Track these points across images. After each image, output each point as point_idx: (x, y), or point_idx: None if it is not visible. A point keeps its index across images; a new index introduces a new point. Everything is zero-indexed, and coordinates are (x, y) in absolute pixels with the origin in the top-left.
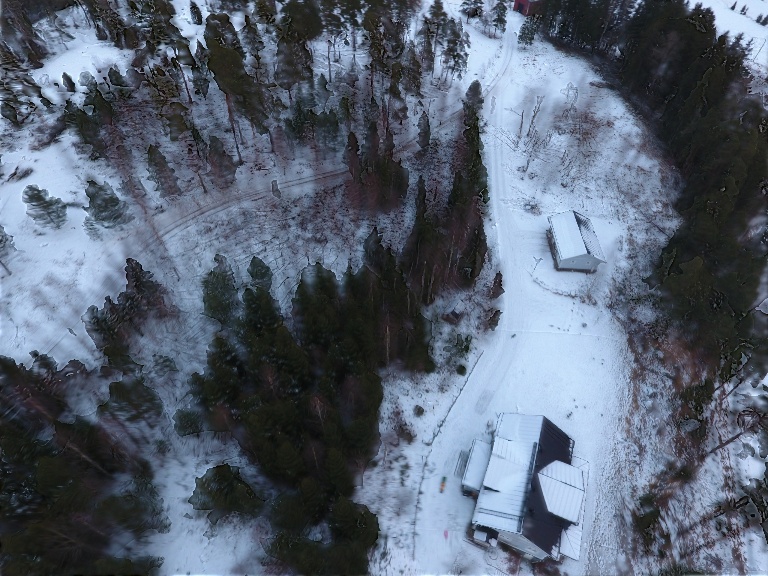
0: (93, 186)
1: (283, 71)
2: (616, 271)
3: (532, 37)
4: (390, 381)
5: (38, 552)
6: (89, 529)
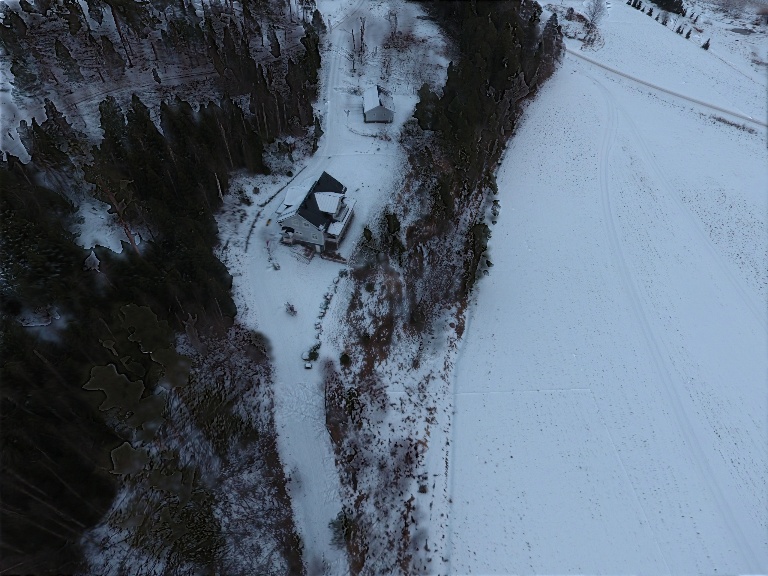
0: (16, 65)
1: None
2: (408, 122)
3: None
4: (238, 178)
5: (4, 200)
6: (33, 198)
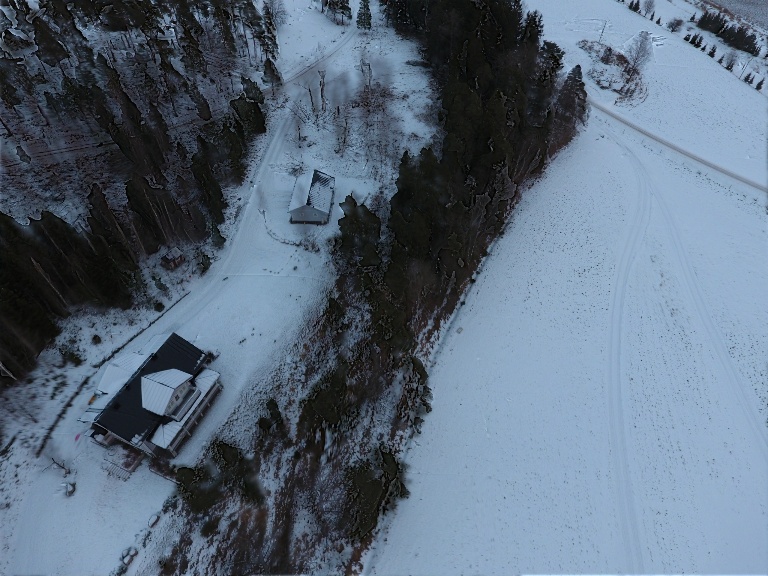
0: None
1: (44, 48)
2: None
3: (369, 22)
4: (79, 316)
5: None
6: None
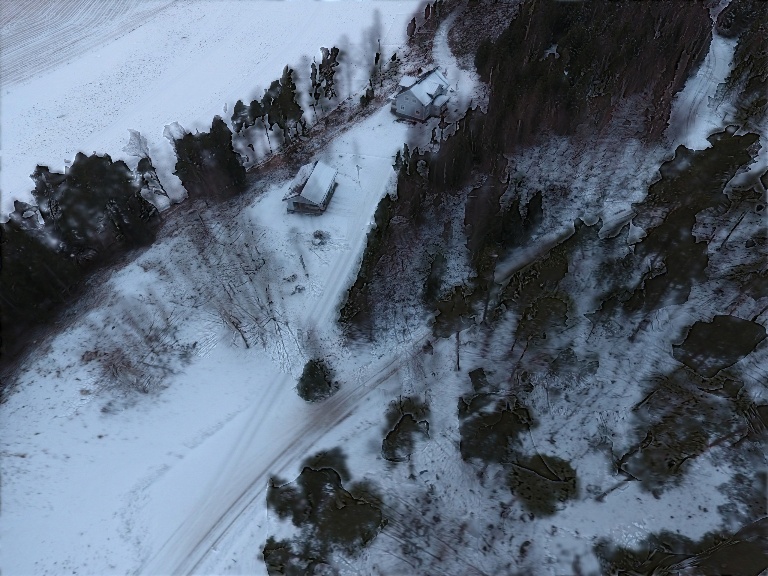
0: None
1: None
2: None
3: None
4: None
5: None
6: None
